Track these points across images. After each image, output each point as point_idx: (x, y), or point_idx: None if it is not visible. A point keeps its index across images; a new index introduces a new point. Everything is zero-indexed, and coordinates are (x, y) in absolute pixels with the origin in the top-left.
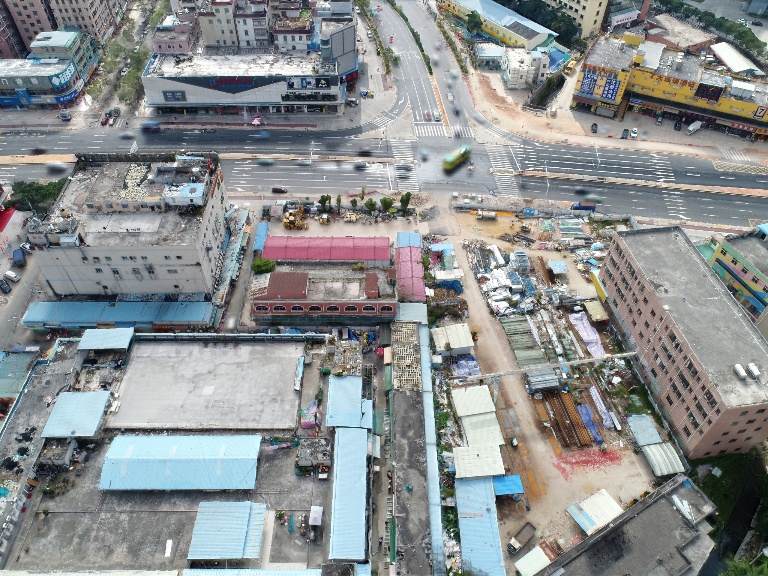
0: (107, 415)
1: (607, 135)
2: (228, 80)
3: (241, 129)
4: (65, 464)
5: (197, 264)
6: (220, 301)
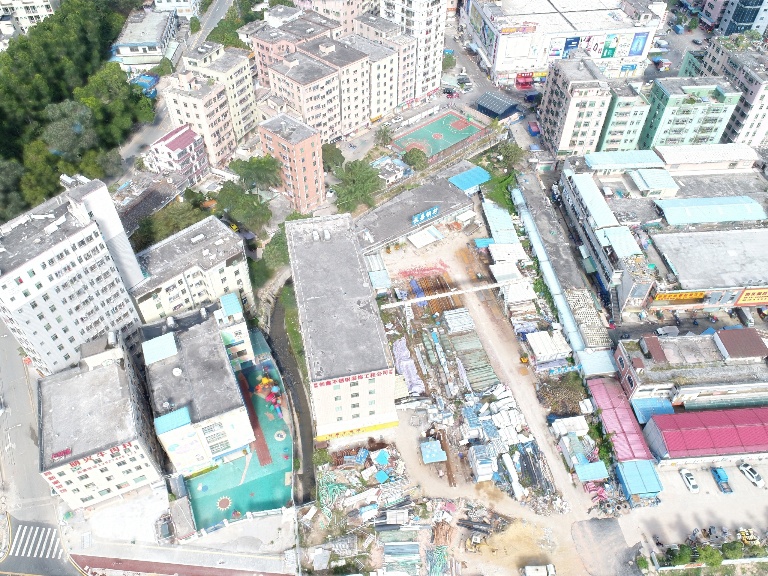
0: None
1: None
2: None
3: None
4: None
5: None
6: None
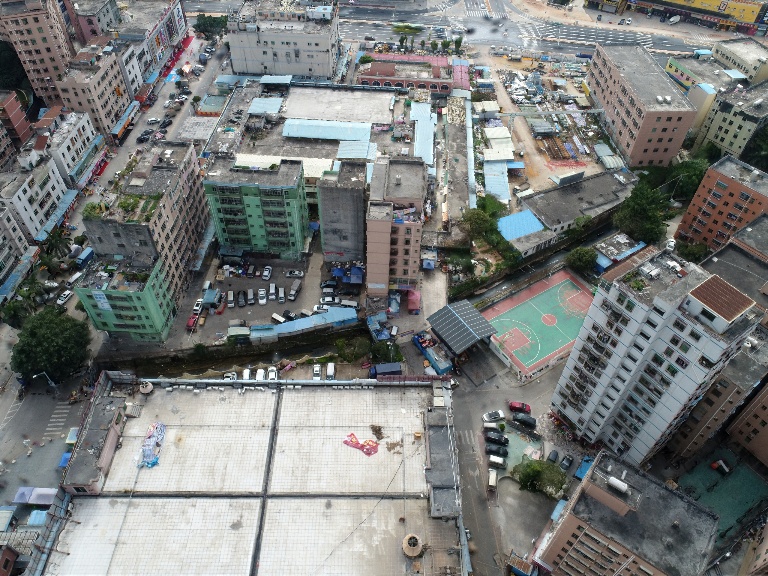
0: (280, 113)
1: (608, 22)
2: None
3: (340, 6)
4: (261, 127)
5: (327, 51)
6: (337, 82)
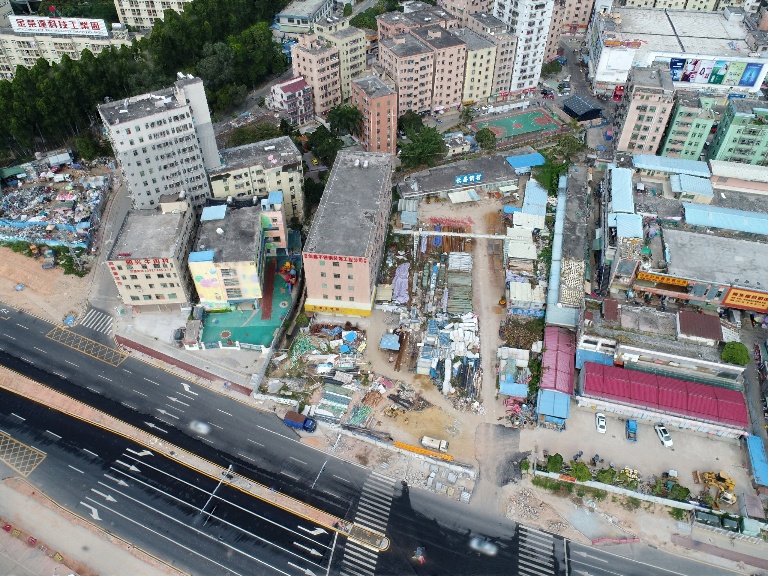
0: None
1: None
2: None
3: None
4: None
5: None
6: None
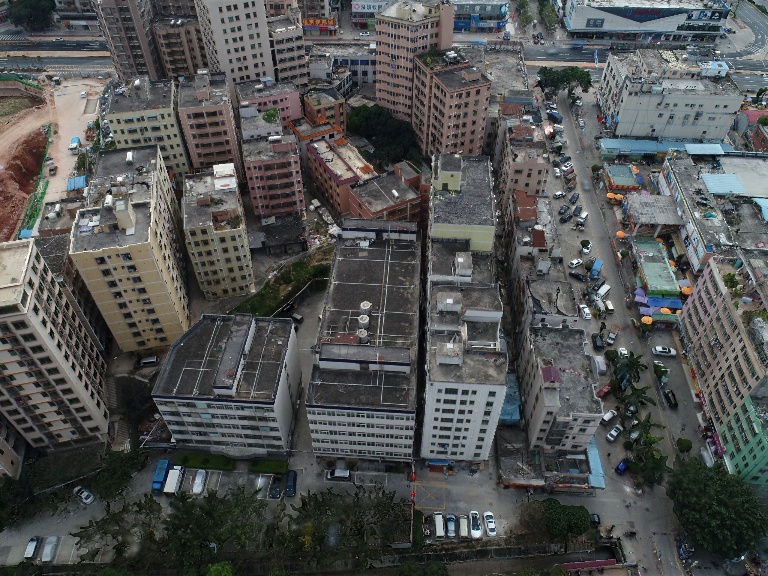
0: None
1: None
2: (642, 11)
3: None
4: None
5: (734, 113)
6: None
